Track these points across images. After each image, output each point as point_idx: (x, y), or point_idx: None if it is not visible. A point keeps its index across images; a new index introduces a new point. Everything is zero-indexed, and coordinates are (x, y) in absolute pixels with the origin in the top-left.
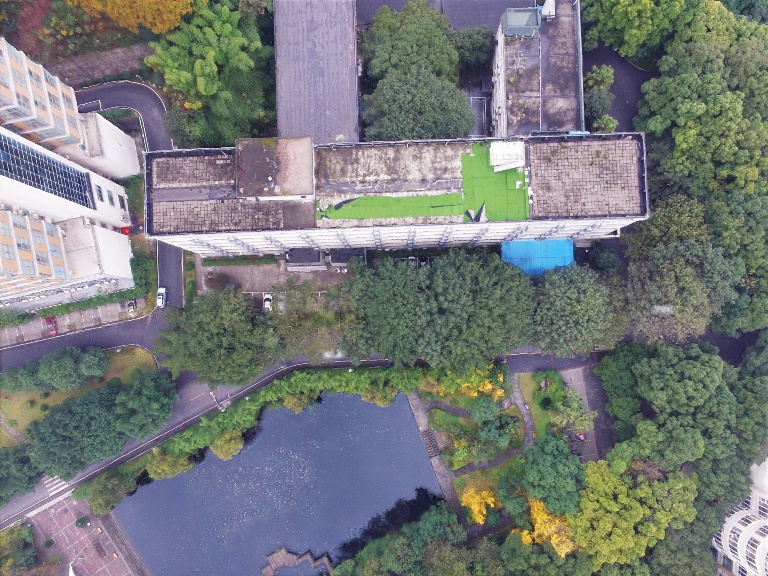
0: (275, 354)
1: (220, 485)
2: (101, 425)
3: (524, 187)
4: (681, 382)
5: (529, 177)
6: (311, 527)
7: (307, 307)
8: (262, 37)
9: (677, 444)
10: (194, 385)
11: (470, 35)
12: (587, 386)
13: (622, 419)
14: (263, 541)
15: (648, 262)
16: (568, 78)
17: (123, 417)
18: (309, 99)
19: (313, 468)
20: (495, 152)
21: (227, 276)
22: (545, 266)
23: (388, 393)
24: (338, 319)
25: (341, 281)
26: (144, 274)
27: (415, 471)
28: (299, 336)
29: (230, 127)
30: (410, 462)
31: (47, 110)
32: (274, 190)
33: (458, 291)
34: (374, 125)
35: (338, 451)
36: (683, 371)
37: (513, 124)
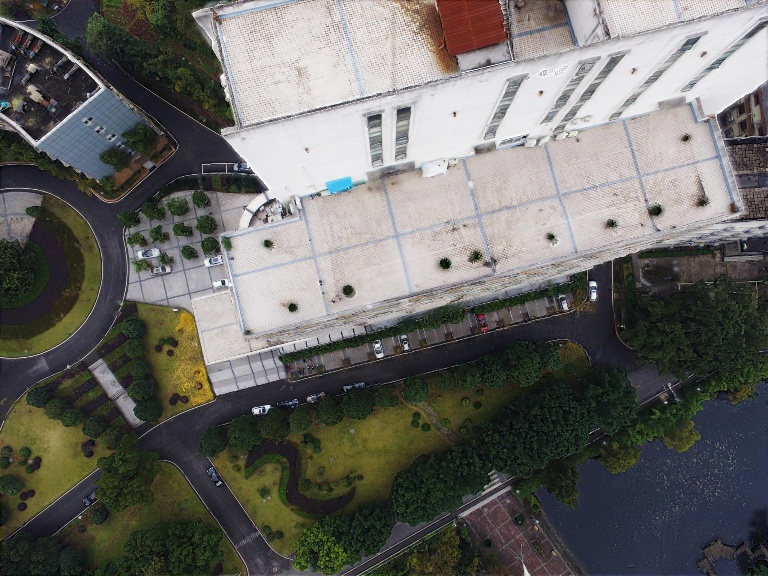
0: None
1: (650, 479)
2: (576, 419)
3: None
4: None
5: None
6: (743, 518)
7: None
8: None
9: None
10: (628, 378)
11: None
12: None
13: None
14: (697, 534)
15: None
16: None
17: (591, 411)
18: None
19: (742, 459)
20: None
21: (665, 268)
22: None
23: None
24: None
25: None
26: None
27: None
28: None
29: None
30: None
31: None
32: None
33: None
34: None
35: (765, 441)
36: None
37: None
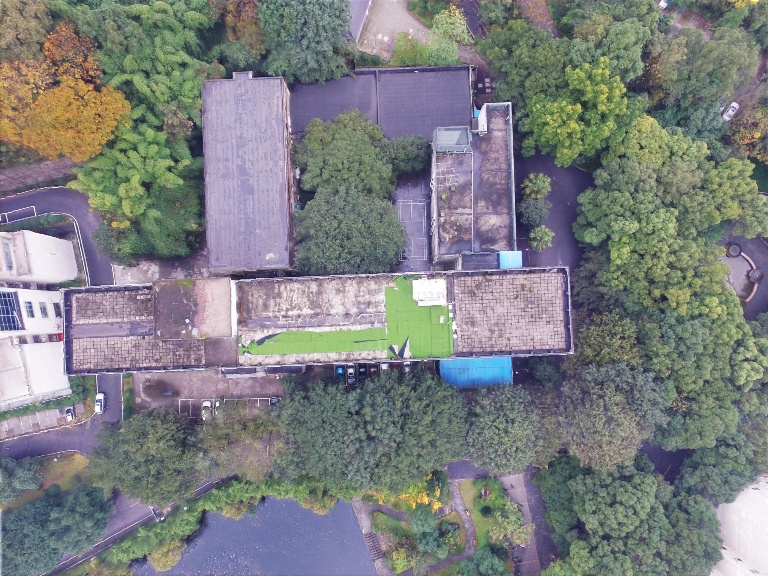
0: (209, 471)
1: None
2: (35, 542)
3: (448, 322)
4: (613, 506)
5: (453, 311)
6: None
7: (235, 433)
8: (195, 146)
9: (607, 573)
10: None
11: (404, 146)
12: (528, 492)
13: (559, 533)
14: None
15: (581, 382)
16: (501, 194)
17: (58, 532)
18: (239, 217)
19: (256, 571)
20: (417, 290)
21: (165, 383)
22: (483, 376)
23: (327, 503)
24: (267, 446)
25: (280, 388)
26: (82, 381)
27: (358, 574)
28: (230, 458)
29: (163, 239)
30: (353, 565)
31: None
32: (192, 333)
33: (386, 420)
34: (303, 247)
35: (281, 554)
36: (615, 494)
37: (445, 242)
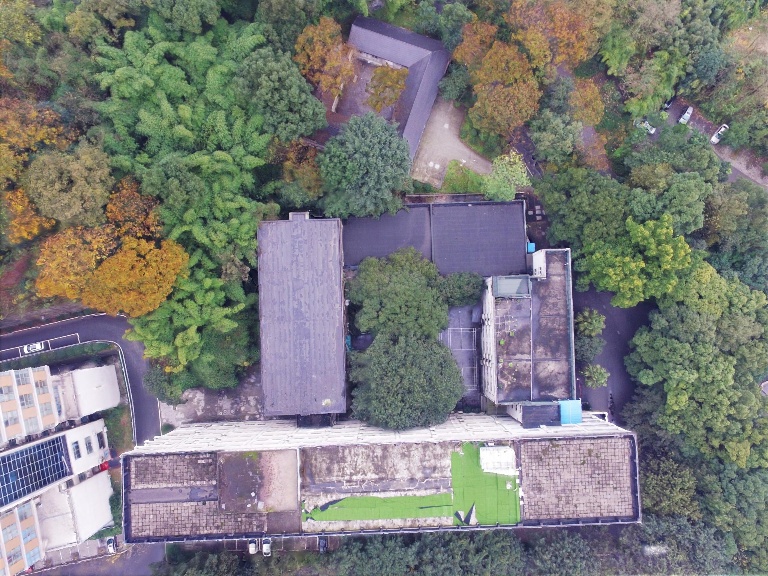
0: None
1: None
2: None
3: (515, 489)
4: None
5: (520, 477)
6: None
7: None
8: None
9: None
10: None
11: (460, 285)
12: None
13: None
14: None
15: (640, 532)
16: (559, 340)
17: None
18: (295, 362)
19: None
20: (485, 460)
21: None
22: None
23: None
24: None
25: None
26: None
27: None
28: None
29: (213, 375)
30: None
31: (19, 420)
32: (257, 506)
33: None
34: (362, 396)
35: None
36: None
37: (504, 388)
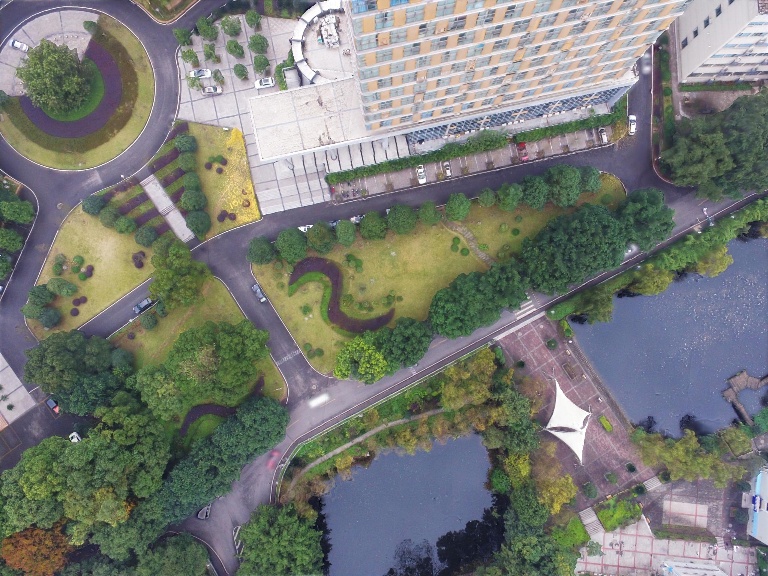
0: None
1: (679, 311)
2: (614, 233)
3: None
4: None
5: None
6: None
7: None
8: None
9: None
10: None
11: None
12: None
13: None
14: (724, 365)
15: None
16: None
17: (629, 228)
18: None
19: None
20: None
21: (704, 101)
22: None
23: None
24: None
25: None
26: None
27: None
28: None
29: None
30: None
31: None
32: None
33: None
34: None
35: None
36: None
37: None
